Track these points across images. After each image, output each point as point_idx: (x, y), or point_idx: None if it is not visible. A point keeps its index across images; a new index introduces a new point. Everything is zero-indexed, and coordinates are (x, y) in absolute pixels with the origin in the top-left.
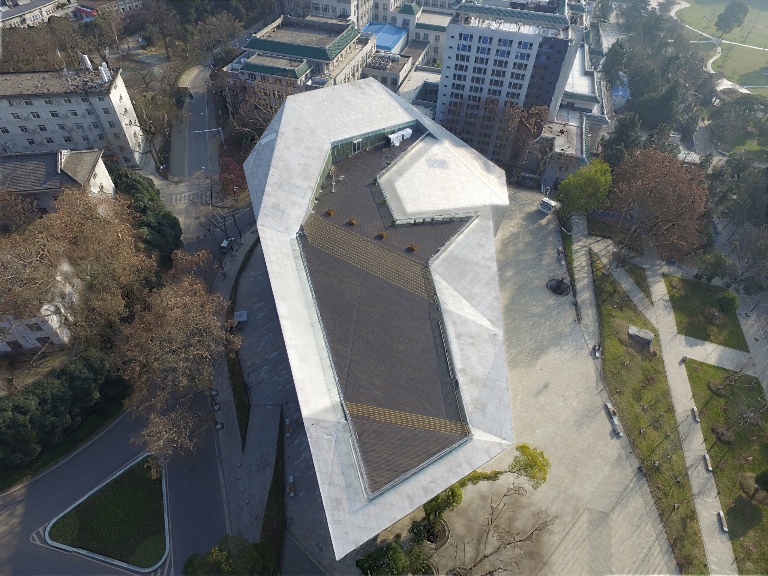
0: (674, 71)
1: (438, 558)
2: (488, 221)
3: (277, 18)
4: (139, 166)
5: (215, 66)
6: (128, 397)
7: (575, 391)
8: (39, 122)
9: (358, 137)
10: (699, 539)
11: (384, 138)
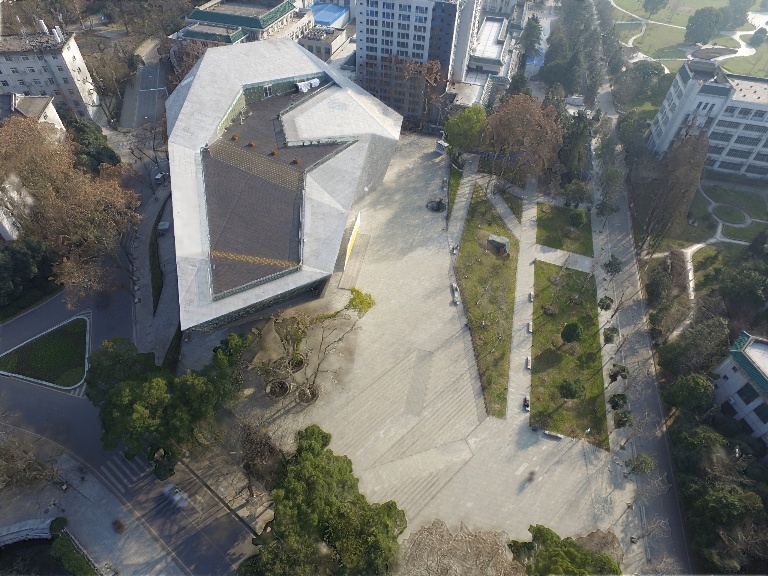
0: None
1: (254, 330)
2: (365, 144)
3: None
4: (93, 120)
5: None
6: (57, 265)
7: (430, 276)
8: (1, 78)
9: (268, 83)
10: (506, 373)
11: (294, 86)
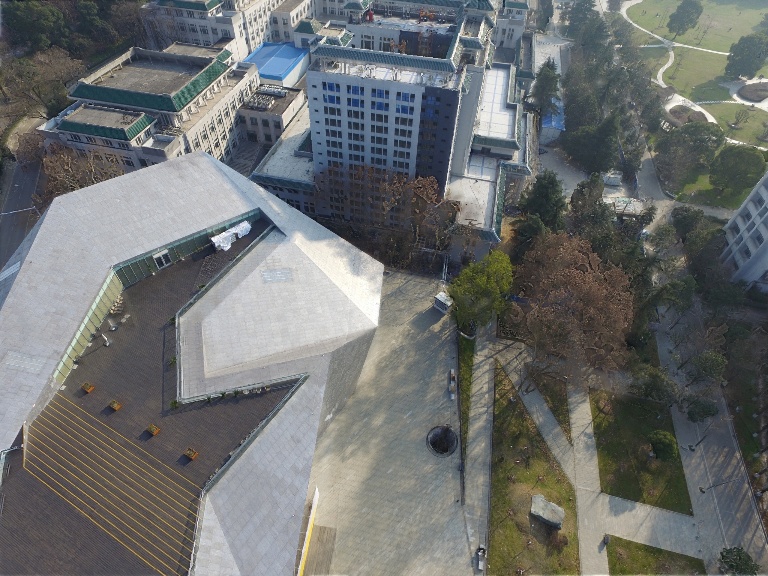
0: (619, 88)
1: None
2: (319, 388)
3: (150, 42)
4: None
5: (49, 115)
6: None
7: None
8: None
9: (161, 249)
10: None
11: (209, 240)
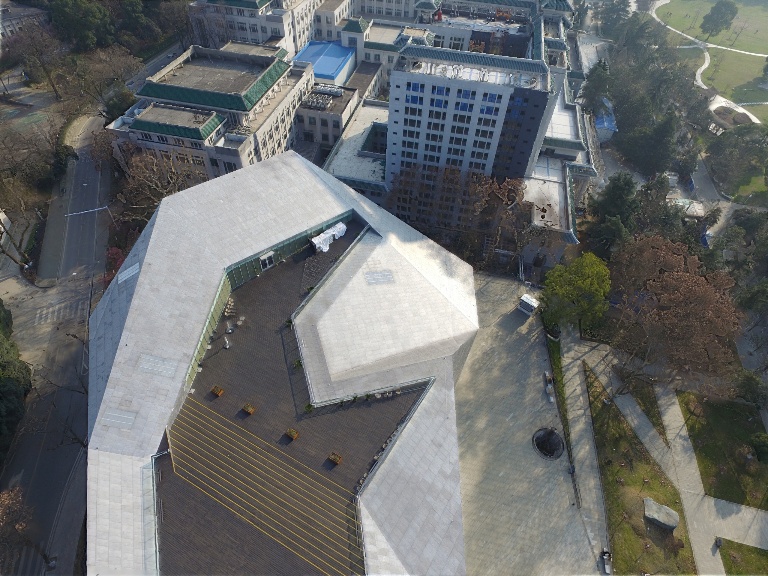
0: None
1: None
2: (448, 391)
3: (197, 40)
4: None
5: (109, 113)
6: None
7: None
8: None
9: (267, 250)
10: None
11: (307, 241)
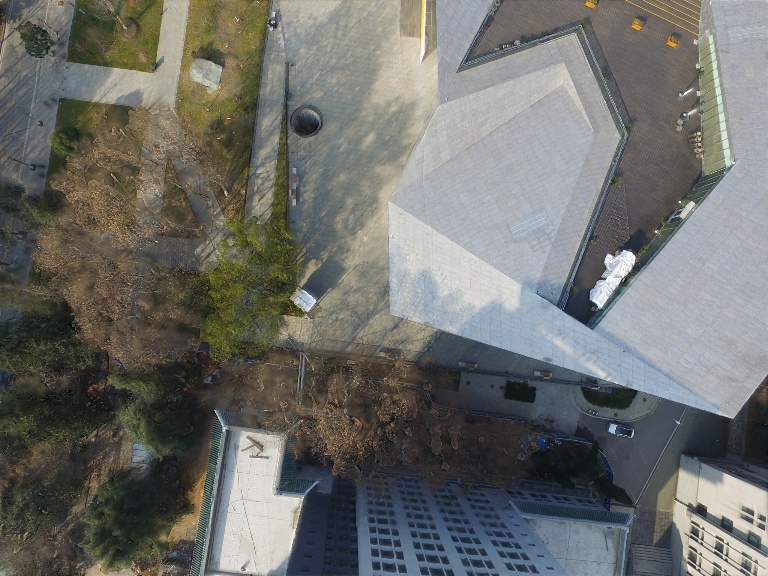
0: None
1: None
2: (444, 57)
3: None
4: None
5: None
6: None
7: None
8: None
9: None
10: None
11: None
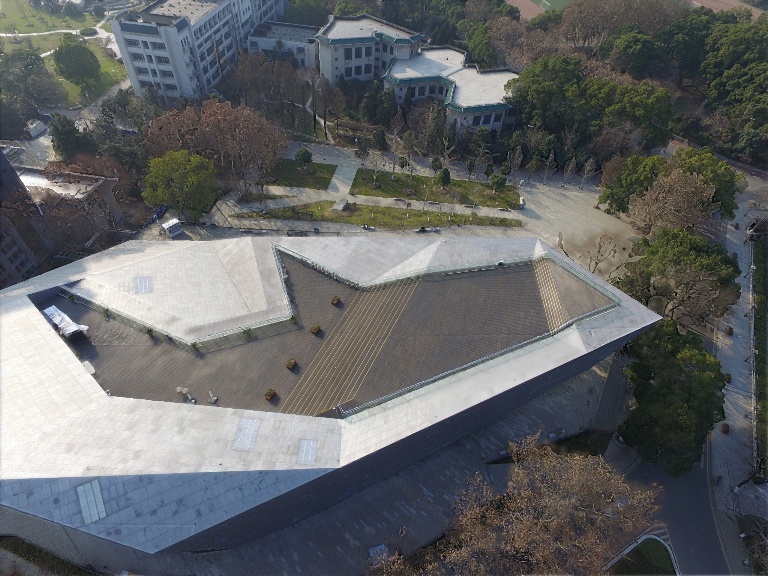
0: None
1: None
2: (283, 240)
3: None
4: None
5: None
6: None
7: None
8: None
9: None
10: None
11: None
